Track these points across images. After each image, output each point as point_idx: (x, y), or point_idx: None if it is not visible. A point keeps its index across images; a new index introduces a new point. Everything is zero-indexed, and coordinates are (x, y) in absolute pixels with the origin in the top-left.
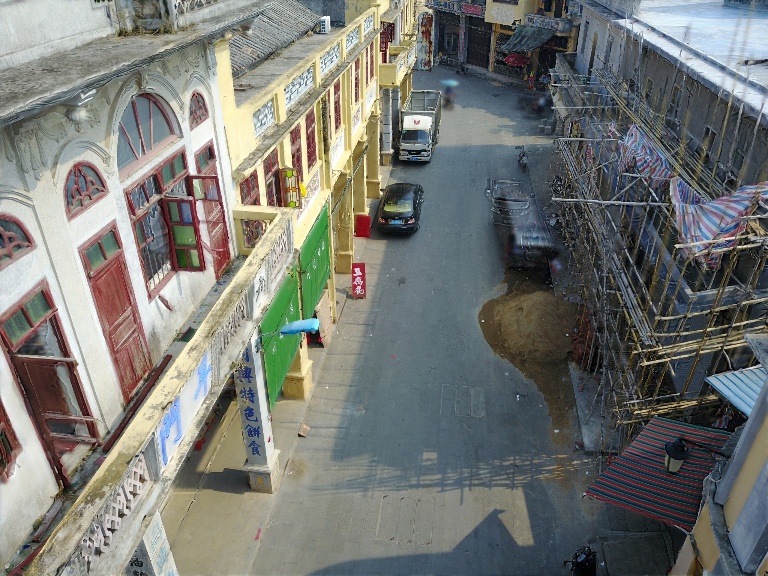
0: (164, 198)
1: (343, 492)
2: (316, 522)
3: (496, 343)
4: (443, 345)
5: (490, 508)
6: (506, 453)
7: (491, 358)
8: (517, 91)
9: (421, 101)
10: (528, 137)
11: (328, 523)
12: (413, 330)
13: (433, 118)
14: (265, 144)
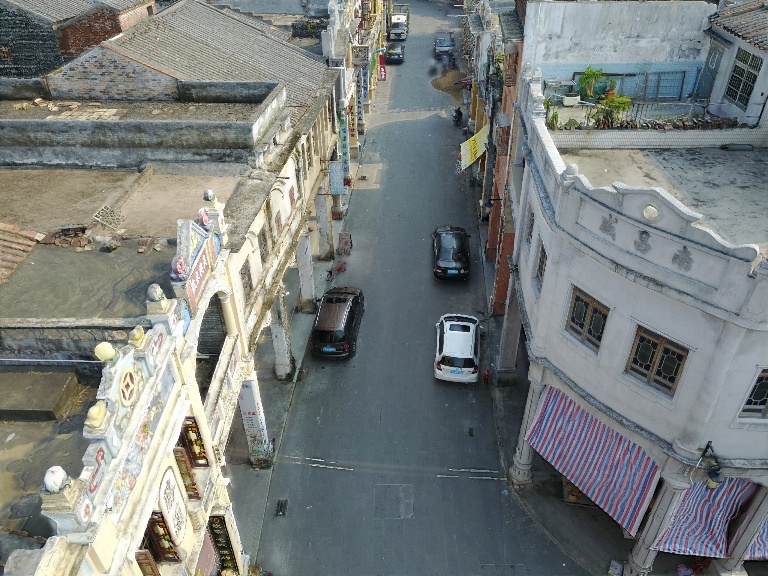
0: (362, 3)
1: (390, 113)
2: (384, 117)
3: (437, 87)
4: (418, 88)
5: (434, 113)
6: (440, 106)
7: (435, 90)
8: (453, 8)
9: (399, 10)
10: (456, 28)
11: (388, 117)
12: (406, 86)
13: (406, 16)
14: (369, 0)
